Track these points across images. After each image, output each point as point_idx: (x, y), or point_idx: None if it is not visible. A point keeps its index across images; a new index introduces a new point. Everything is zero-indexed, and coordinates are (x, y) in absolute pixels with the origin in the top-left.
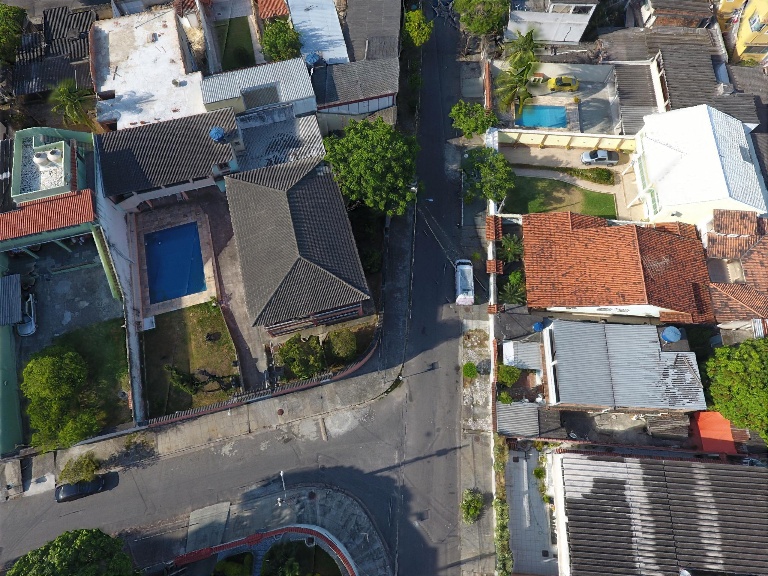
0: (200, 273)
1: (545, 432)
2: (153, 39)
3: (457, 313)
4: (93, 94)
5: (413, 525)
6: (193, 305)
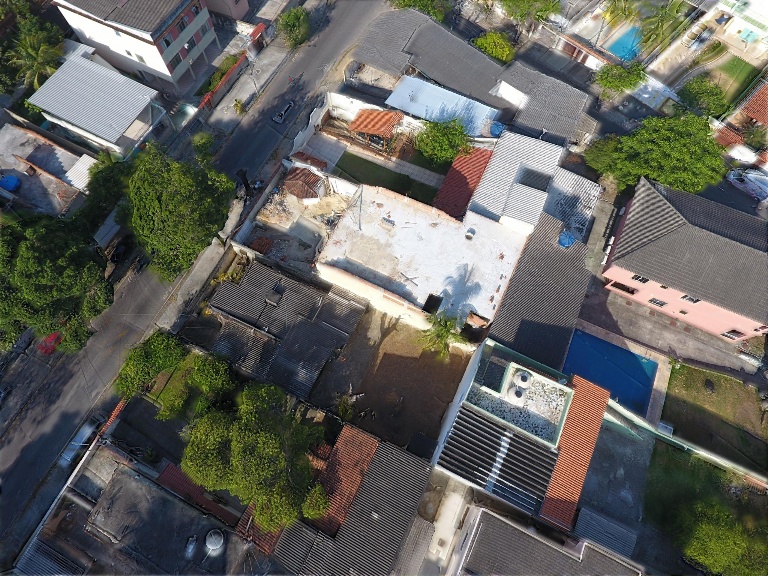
0: (626, 361)
1: None
2: (392, 224)
3: (767, 208)
4: None
5: None
6: (668, 384)
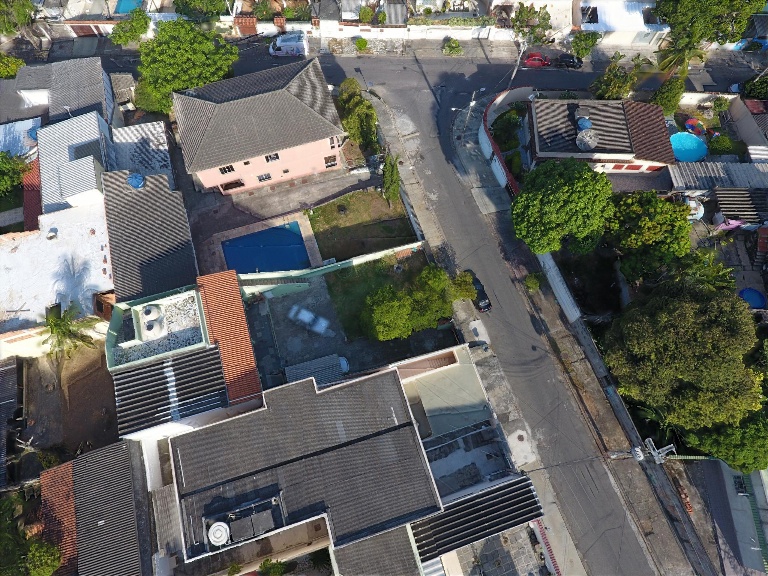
0: (277, 237)
1: (403, 2)
2: None
3: None
4: (22, 389)
5: (469, 81)
6: (312, 229)
